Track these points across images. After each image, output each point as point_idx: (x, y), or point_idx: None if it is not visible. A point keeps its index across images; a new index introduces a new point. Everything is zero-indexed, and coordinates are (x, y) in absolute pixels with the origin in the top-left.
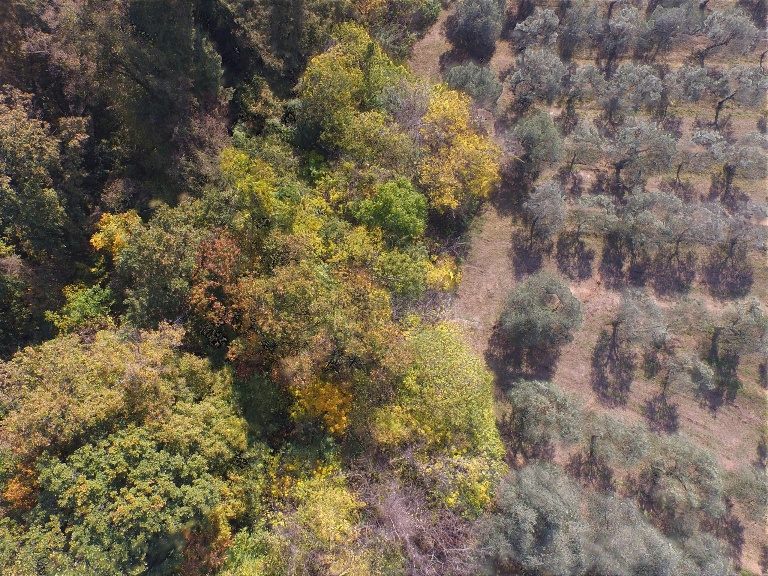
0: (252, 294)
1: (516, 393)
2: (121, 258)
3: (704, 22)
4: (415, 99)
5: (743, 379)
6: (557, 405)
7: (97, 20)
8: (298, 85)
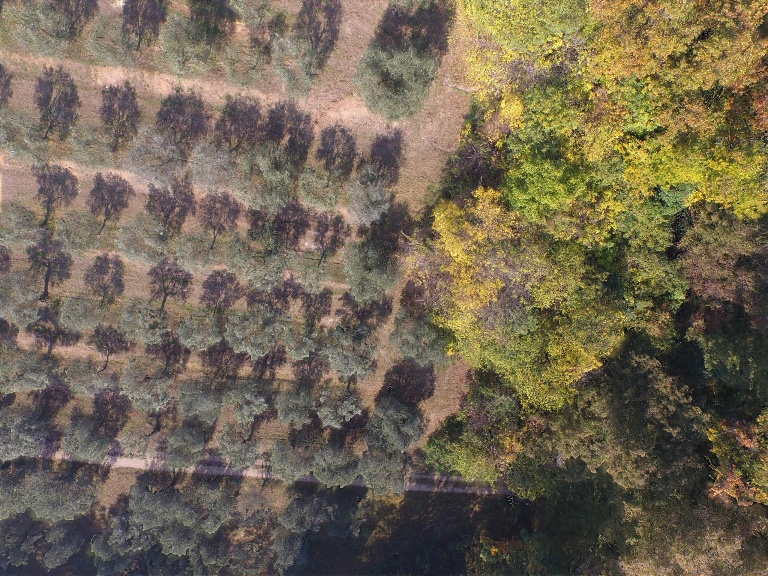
0: (751, 58)
1: None
2: None
3: None
4: None
5: (185, 7)
6: None
7: None
8: None
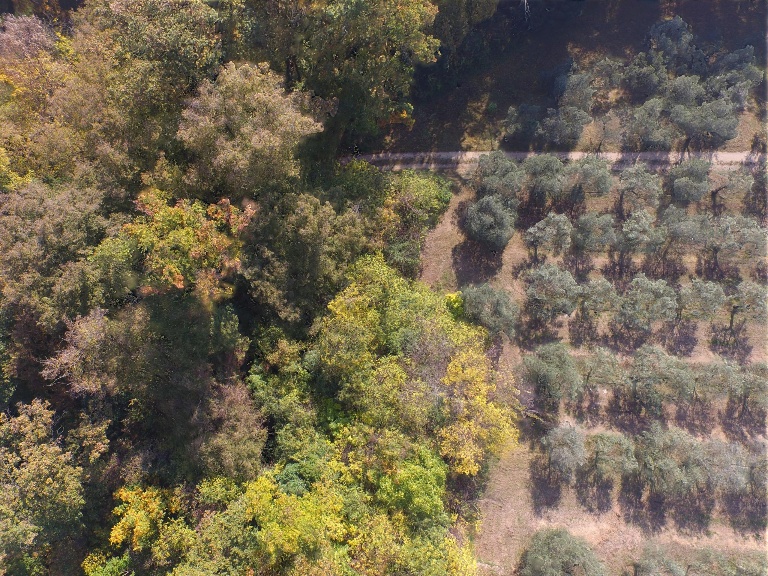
0: None
1: None
2: (141, 547)
3: (718, 229)
4: (433, 350)
5: None
6: None
7: (117, 335)
8: (314, 326)
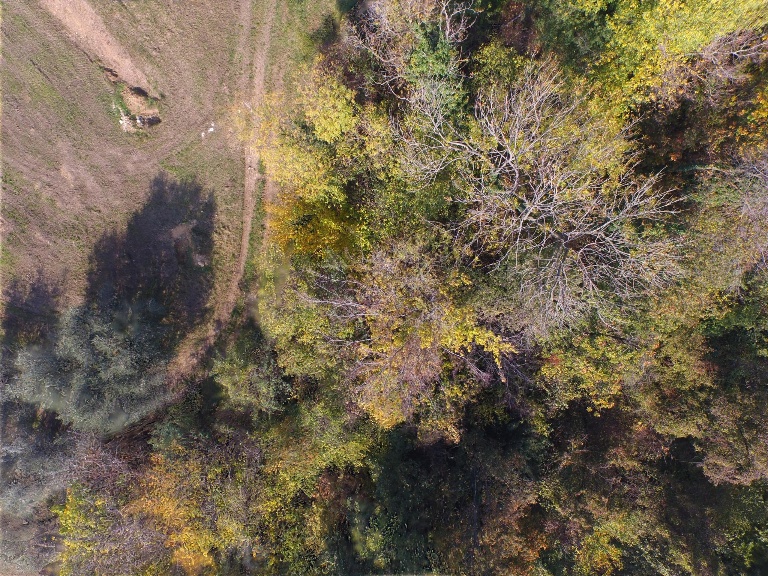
0: None
1: (54, 558)
2: None
3: None
4: None
5: None
6: (7, 557)
7: None
8: None
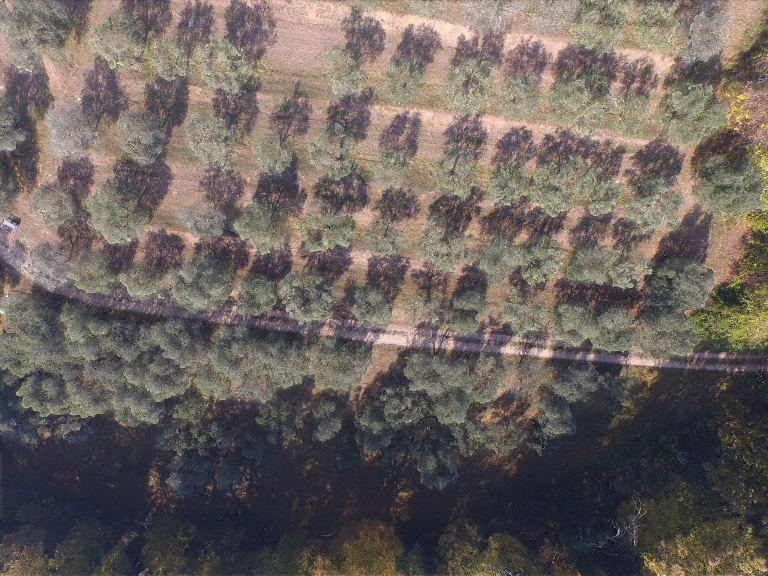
0: None
1: None
2: None
3: None
4: None
5: None
6: None
7: None
8: None
